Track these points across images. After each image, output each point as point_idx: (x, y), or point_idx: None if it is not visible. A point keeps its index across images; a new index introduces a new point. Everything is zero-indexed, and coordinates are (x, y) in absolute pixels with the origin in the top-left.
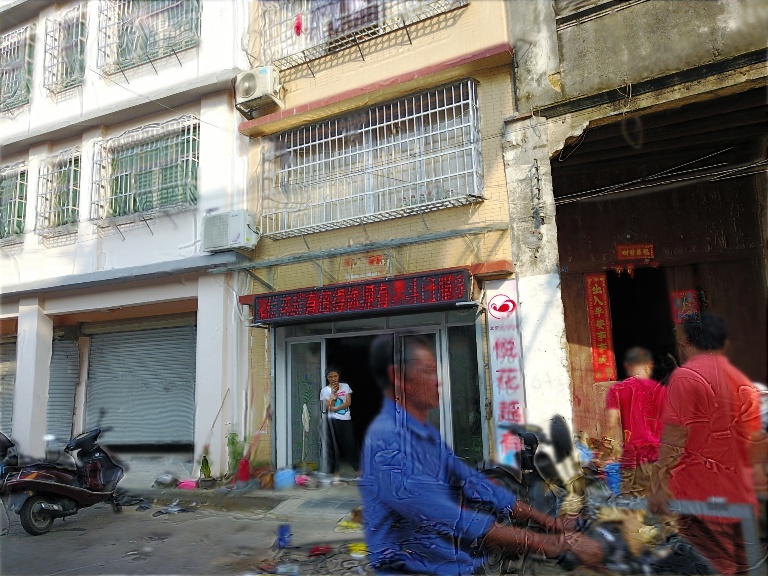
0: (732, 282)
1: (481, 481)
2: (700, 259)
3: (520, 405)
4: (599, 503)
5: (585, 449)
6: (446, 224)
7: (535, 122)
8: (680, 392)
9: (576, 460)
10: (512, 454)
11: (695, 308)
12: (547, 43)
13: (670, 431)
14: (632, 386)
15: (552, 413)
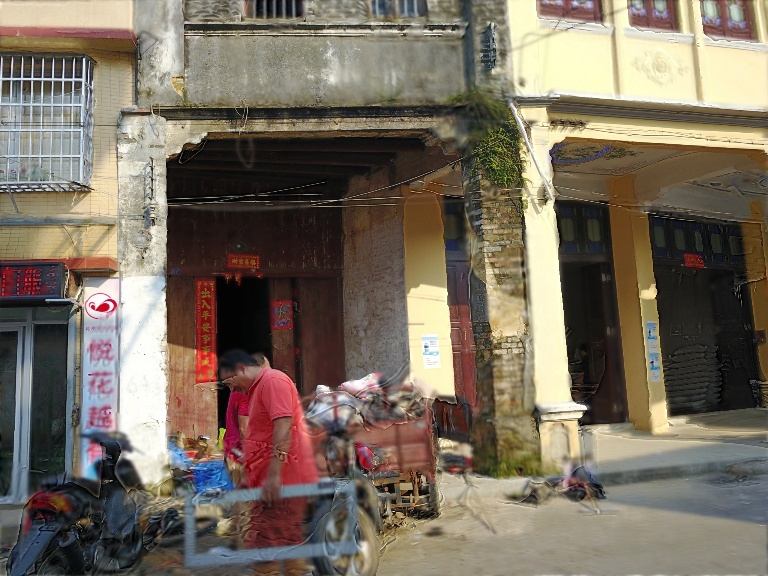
0: (318, 296)
1: (47, 500)
2: (296, 274)
3: (112, 410)
4: (184, 503)
5: (180, 449)
6: (42, 209)
7: (154, 120)
8: (271, 391)
9: (166, 462)
10: (98, 462)
11: (289, 316)
12: (173, 44)
13: (259, 427)
14: (230, 386)
15: (146, 417)
